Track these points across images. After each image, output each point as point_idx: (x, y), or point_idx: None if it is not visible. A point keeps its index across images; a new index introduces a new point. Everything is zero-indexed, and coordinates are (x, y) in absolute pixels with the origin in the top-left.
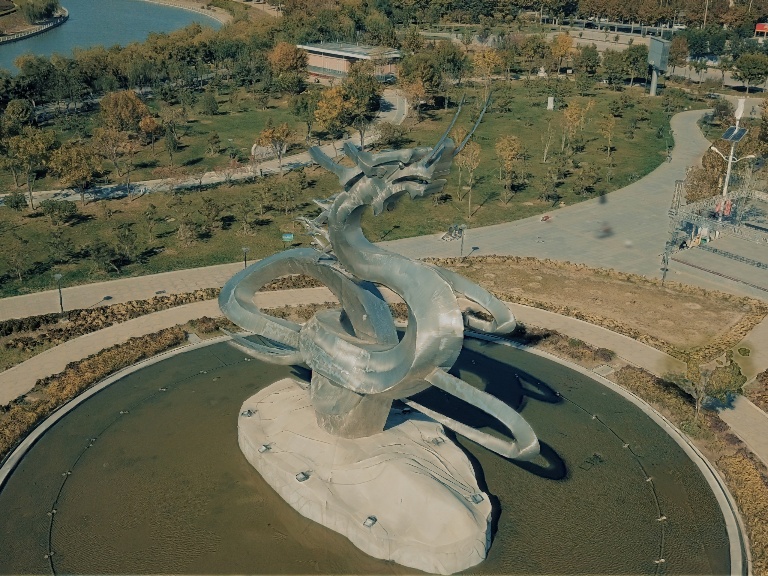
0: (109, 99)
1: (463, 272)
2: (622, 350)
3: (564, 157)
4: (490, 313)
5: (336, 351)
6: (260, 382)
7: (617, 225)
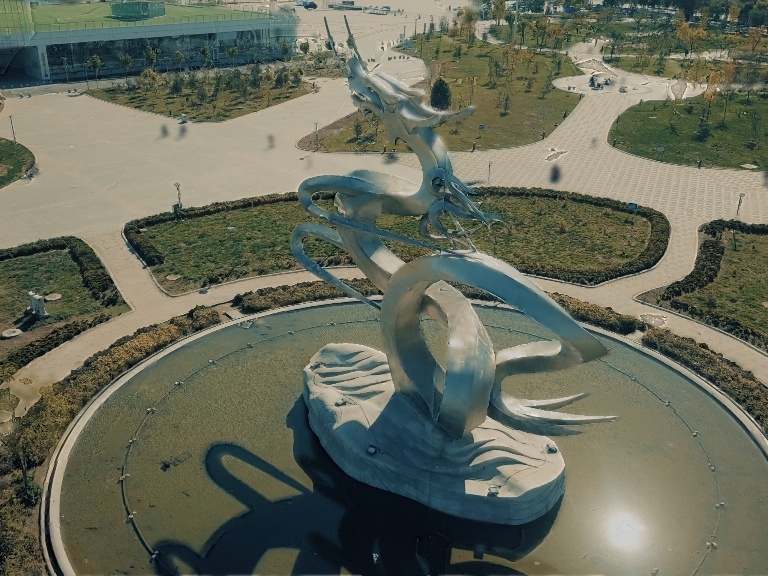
0: None
1: None
2: None
3: None
4: None
5: None
6: (589, 568)
7: None
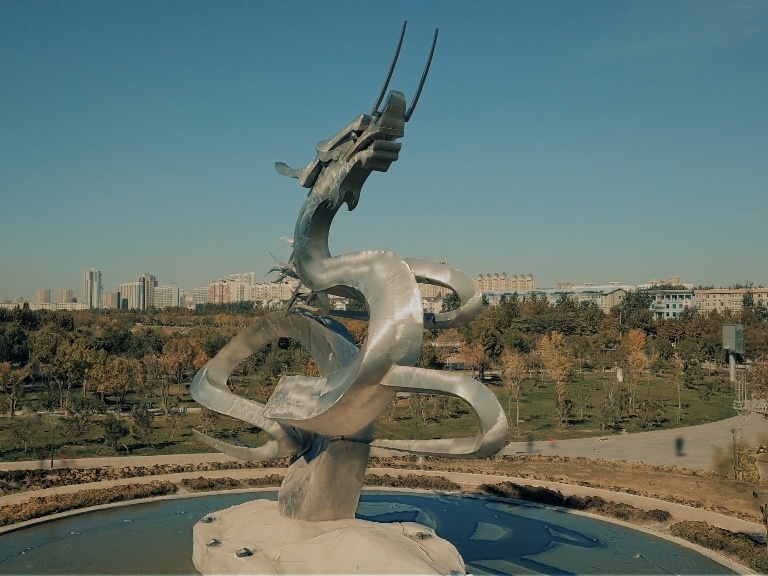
0: (170, 344)
1: (501, 464)
2: (681, 514)
3: (626, 394)
4: (452, 288)
5: (293, 388)
6: None
7: (685, 445)
